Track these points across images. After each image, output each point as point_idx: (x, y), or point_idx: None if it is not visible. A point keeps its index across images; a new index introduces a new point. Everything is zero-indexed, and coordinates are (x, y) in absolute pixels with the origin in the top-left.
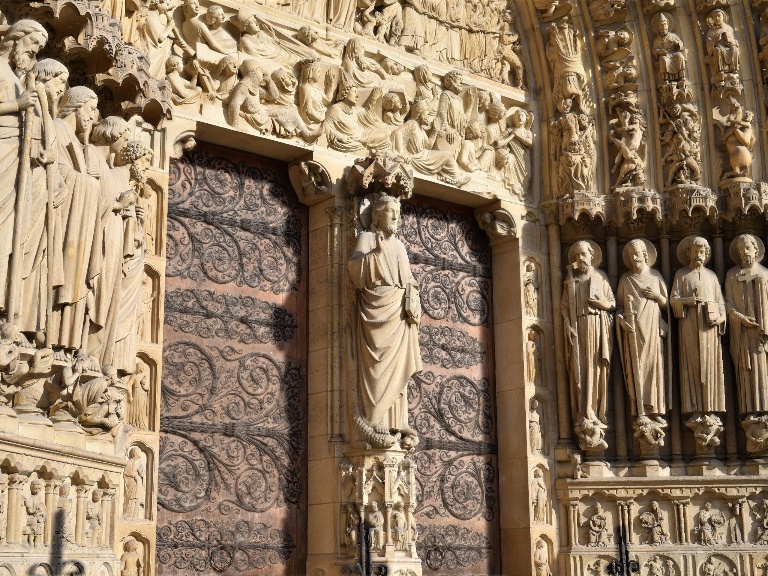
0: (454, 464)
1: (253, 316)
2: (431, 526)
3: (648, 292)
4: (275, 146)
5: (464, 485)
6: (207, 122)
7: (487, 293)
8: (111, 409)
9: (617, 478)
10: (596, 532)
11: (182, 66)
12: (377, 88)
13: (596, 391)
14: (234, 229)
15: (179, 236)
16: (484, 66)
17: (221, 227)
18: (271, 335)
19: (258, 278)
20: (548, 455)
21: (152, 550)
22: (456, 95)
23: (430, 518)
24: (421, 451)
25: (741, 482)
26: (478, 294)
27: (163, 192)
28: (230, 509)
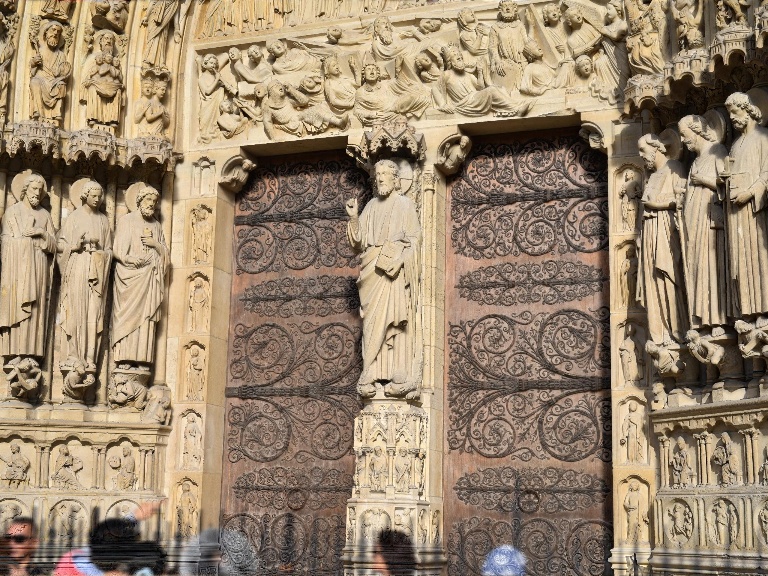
0: (558, 404)
1: (330, 291)
2: (525, 469)
3: (692, 178)
4: (322, 142)
5: (572, 425)
6: (250, 144)
7: None
8: (119, 389)
9: None
10: (678, 472)
11: (227, 107)
12: (397, 56)
13: (662, 307)
14: (313, 220)
15: (265, 239)
16: None
17: (300, 222)
18: (347, 305)
19: (335, 257)
20: (647, 385)
21: (199, 491)
22: (508, 23)
23: (524, 461)
24: (514, 393)
25: None
26: (597, 217)
27: (212, 212)
28: (306, 458)
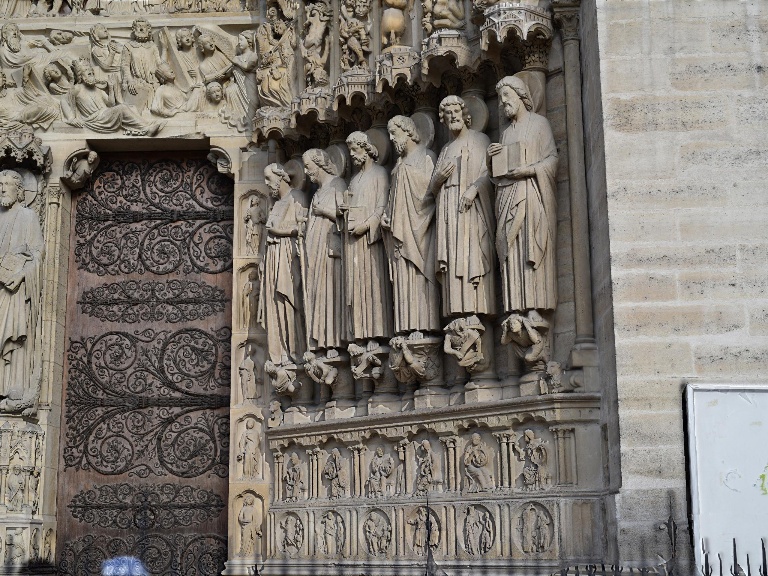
0: (178, 421)
1: None
2: (142, 485)
3: (314, 208)
4: None
5: (190, 442)
6: None
7: None
8: None
9: (301, 424)
10: (291, 486)
11: None
12: (25, 65)
13: (281, 329)
14: None
15: None
16: (191, 1)
17: None
18: None
19: None
20: (264, 404)
21: None
22: (141, 43)
23: (141, 477)
24: (133, 410)
25: (397, 420)
26: (222, 239)
27: None
28: None
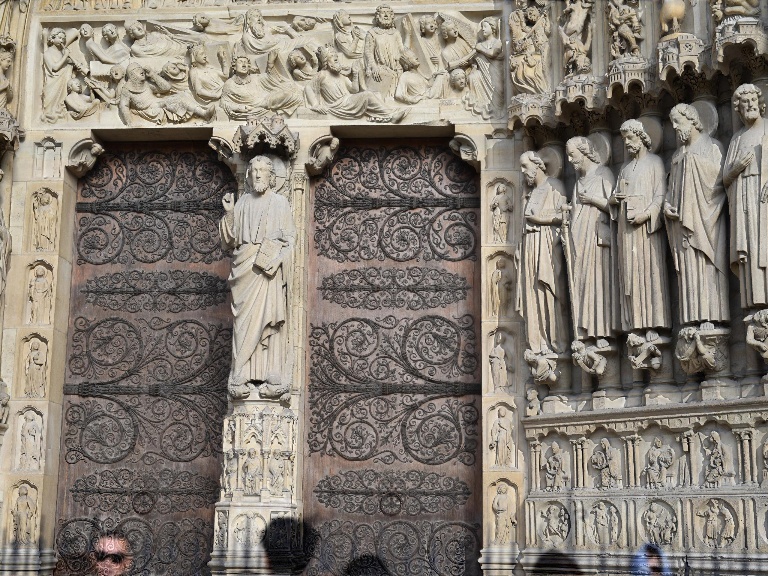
0: (421, 408)
1: (183, 287)
2: (387, 472)
3: (581, 197)
4: (182, 131)
5: (434, 429)
6: (102, 128)
7: (475, 224)
8: None
9: None
10: (552, 475)
11: (77, 86)
12: (270, 51)
13: (541, 317)
14: (165, 212)
15: (110, 228)
16: None
17: (151, 213)
18: (202, 302)
19: (189, 252)
20: (516, 392)
21: (40, 495)
22: (385, 30)
23: (386, 464)
24: (377, 397)
25: (681, 411)
26: (462, 227)
27: (58, 197)
28: (154, 460)
